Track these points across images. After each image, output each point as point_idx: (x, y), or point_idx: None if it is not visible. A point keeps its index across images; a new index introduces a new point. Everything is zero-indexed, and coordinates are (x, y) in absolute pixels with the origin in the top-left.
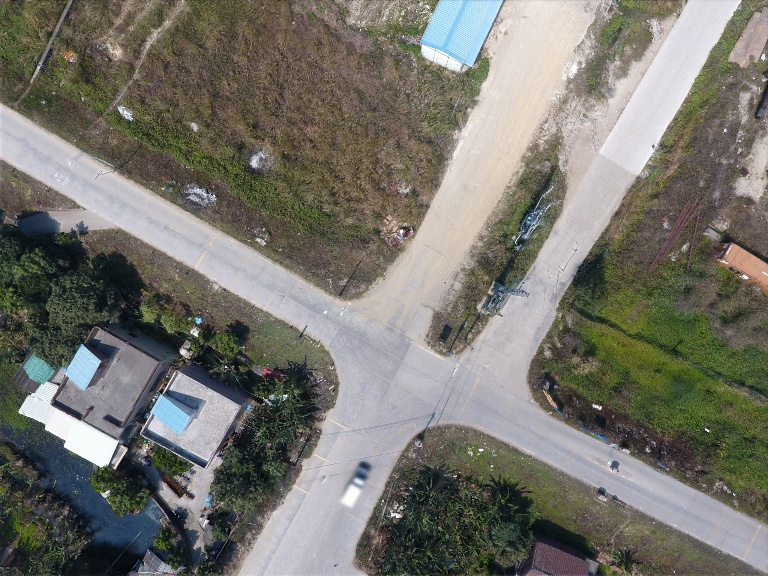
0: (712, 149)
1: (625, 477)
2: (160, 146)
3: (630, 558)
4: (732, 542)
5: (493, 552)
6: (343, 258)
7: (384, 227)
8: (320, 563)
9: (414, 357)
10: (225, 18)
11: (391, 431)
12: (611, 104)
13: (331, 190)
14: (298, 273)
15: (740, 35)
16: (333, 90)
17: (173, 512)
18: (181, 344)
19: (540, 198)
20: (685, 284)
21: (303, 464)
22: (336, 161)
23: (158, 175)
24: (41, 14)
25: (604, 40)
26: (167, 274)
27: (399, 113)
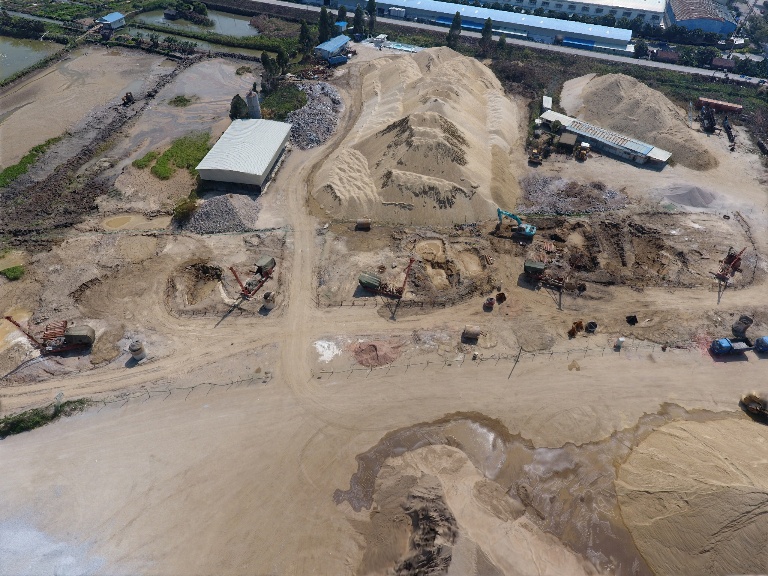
0: None
1: None
2: None
3: None
4: None
5: None
6: None
7: None
8: None
9: None
10: None
11: None
12: None
13: None
14: None
15: None
16: None
17: None
18: None
19: None
20: None
21: None
22: None
23: None
24: None
25: None
26: None
27: None
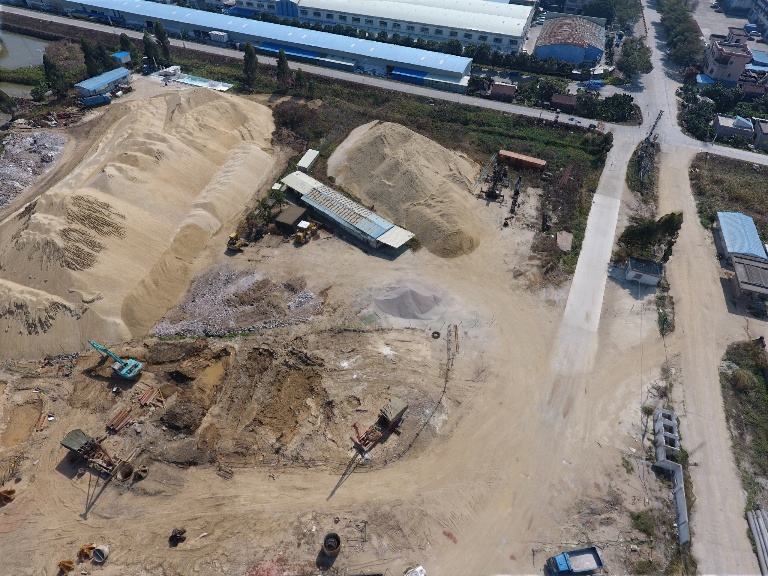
0: None
1: (550, 116)
2: None
3: None
4: None
5: None
6: None
7: None
8: None
9: None
10: None
11: None
12: None
13: None
14: None
15: None
16: None
17: None
18: None
19: None
20: None
21: None
22: None
23: None
24: None
25: None
26: None
27: None
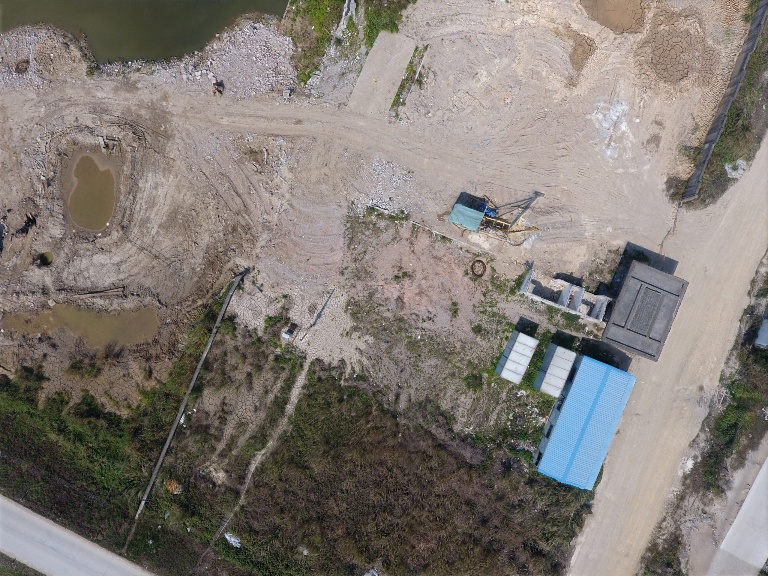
0: None
1: None
2: (271, 575)
3: None
4: None
5: None
6: None
7: None
8: None
9: None
10: (331, 438)
11: None
12: (730, 496)
13: None
14: None
15: None
16: (445, 504)
17: None
18: None
19: None
20: None
21: None
22: None
23: None
24: (142, 445)
25: (720, 435)
26: None
27: (513, 524)
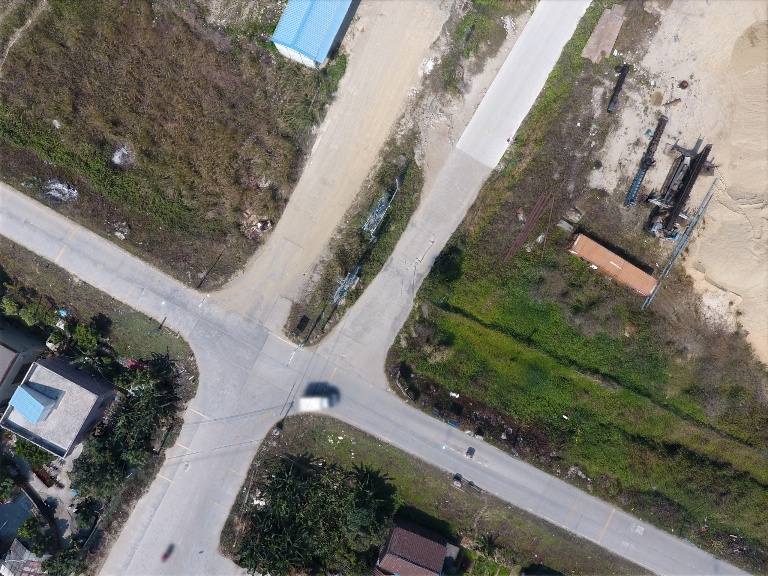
0: (566, 142)
1: (481, 463)
2: (22, 143)
3: (493, 543)
4: (587, 526)
5: (349, 537)
6: (204, 251)
7: (244, 221)
8: (186, 550)
9: (272, 347)
10: (86, 17)
11: (251, 420)
12: (467, 99)
13: (191, 185)
14: (157, 266)
15: (592, 31)
16: (193, 87)
17: (43, 502)
18: (47, 337)
19: (395, 191)
20: (539, 274)
21: (166, 453)
22: (196, 156)
23: (19, 171)
24: None
25: (458, 37)
26: (28, 268)
27: (258, 109)
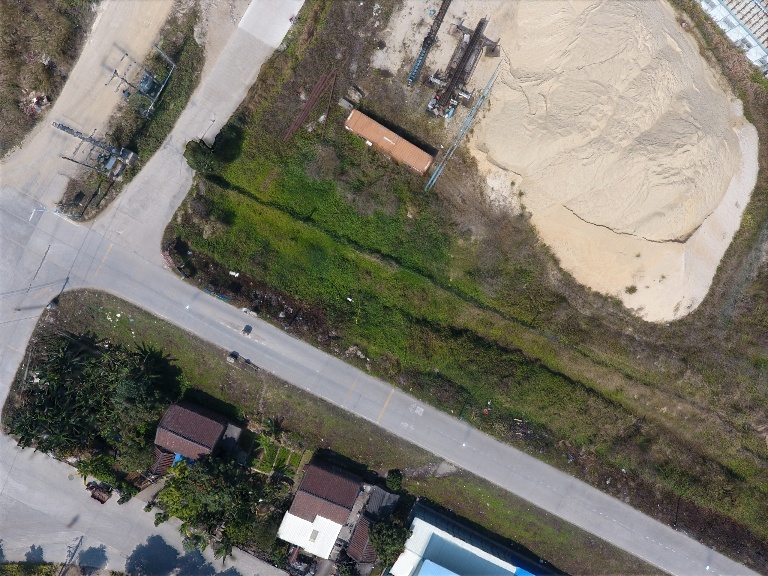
0: (349, 22)
1: (258, 341)
2: None
3: (279, 426)
4: (365, 406)
5: None
6: None
7: (24, 98)
8: None
9: (47, 223)
10: None
11: (28, 296)
12: None
13: None
14: None
15: None
16: None
17: None
18: None
19: (172, 68)
20: (318, 153)
21: None
22: None
23: None
24: None
25: None
26: None
27: None
